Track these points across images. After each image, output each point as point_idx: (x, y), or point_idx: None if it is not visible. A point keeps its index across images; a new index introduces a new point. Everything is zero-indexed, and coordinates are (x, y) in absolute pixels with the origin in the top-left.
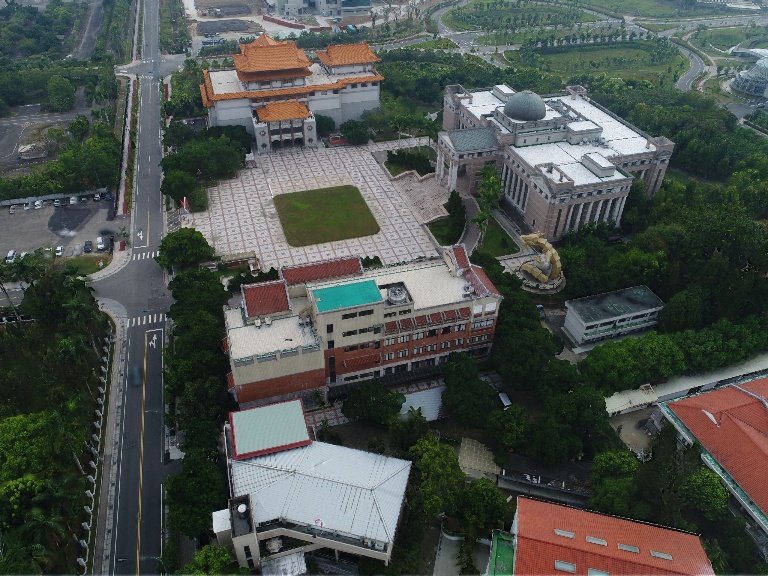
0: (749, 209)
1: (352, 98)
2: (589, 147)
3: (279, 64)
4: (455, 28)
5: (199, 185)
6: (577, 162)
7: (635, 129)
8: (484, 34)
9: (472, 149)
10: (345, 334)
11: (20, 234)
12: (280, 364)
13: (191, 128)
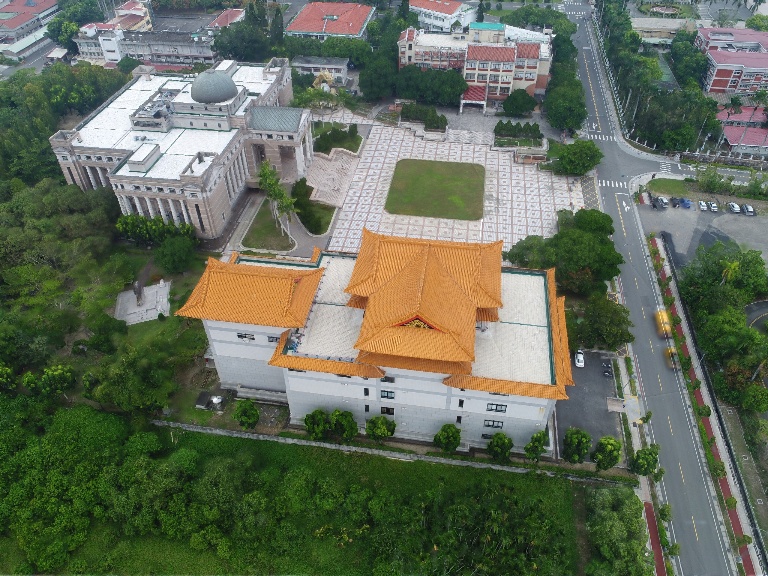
0: None
1: None
2: None
3: None
4: None
5: None
6: None
7: None
8: None
9: None
10: None
11: (763, 240)
12: None
13: (589, 425)
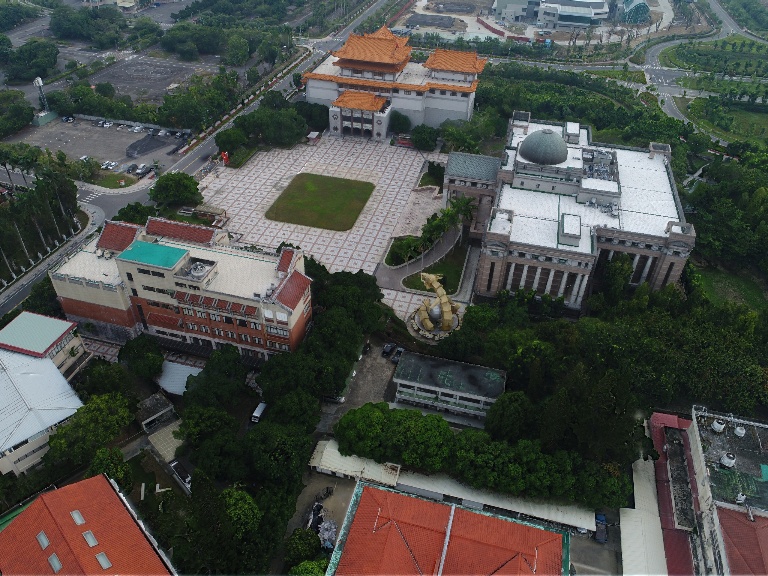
0: (767, 350)
1: (440, 104)
2: (593, 210)
3: (372, 56)
4: (666, 62)
5: (256, 147)
6: (556, 221)
7: (678, 208)
8: (692, 75)
9: (463, 176)
10: (145, 287)
11: (107, 147)
12: (88, 291)
13: (305, 100)
